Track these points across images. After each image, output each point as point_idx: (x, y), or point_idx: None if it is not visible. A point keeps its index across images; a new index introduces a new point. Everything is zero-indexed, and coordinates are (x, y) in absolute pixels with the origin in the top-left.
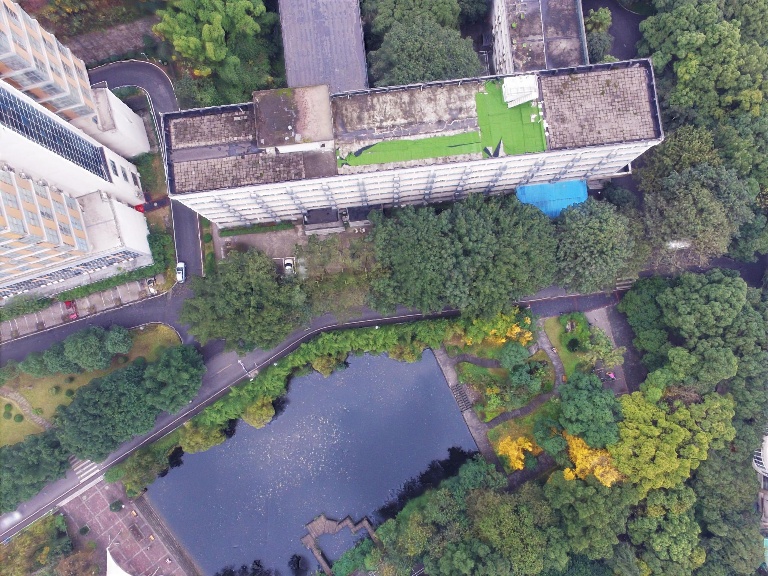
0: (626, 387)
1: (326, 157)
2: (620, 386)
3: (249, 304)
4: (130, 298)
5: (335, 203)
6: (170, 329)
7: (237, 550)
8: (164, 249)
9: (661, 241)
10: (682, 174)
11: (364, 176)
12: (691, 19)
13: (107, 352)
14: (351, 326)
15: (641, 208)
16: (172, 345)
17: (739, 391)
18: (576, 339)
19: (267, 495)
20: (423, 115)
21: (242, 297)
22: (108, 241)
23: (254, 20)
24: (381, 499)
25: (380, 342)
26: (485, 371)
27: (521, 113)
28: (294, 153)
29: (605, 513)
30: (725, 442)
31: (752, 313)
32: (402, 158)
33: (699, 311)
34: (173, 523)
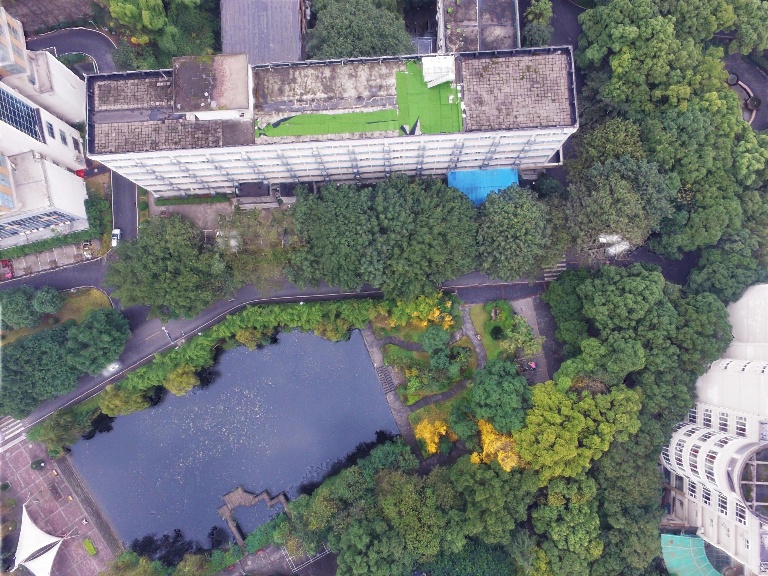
0: (548, 378)
1: (244, 126)
2: (542, 377)
3: (166, 269)
4: (65, 261)
5: (264, 176)
6: (102, 294)
7: (154, 516)
8: (101, 215)
9: (578, 230)
10: (605, 165)
11: (280, 147)
12: (625, 12)
13: (35, 311)
14: (278, 301)
15: (567, 199)
16: None
17: (648, 385)
18: (499, 327)
19: (187, 464)
20: (343, 91)
21: (159, 261)
22: (38, 200)
23: None
24: (299, 475)
25: (304, 318)
26: (410, 354)
27: (440, 94)
28: (213, 121)
29: (500, 496)
30: (630, 435)
31: (667, 308)
32: (319, 132)
33: (613, 302)
34: (93, 485)
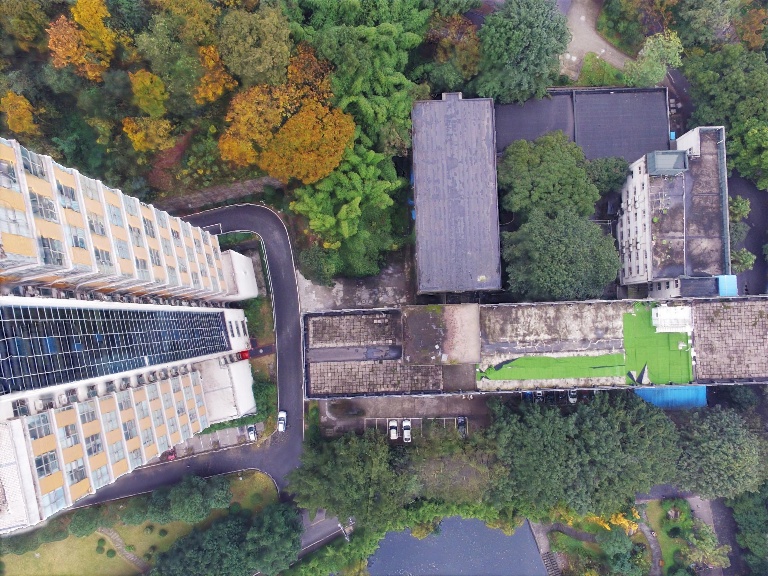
0: None
1: (465, 368)
2: (716, 575)
3: (367, 494)
4: (229, 442)
5: None
6: (267, 477)
7: None
8: (267, 398)
9: None
10: None
11: None
12: None
13: (208, 505)
14: None
15: (764, 413)
16: (268, 493)
17: None
18: (678, 528)
19: None
20: (568, 332)
21: (362, 489)
22: (224, 408)
23: None
24: None
25: (481, 516)
26: (579, 544)
27: (669, 339)
28: None
29: None
30: None
31: None
32: (543, 376)
33: None
34: None
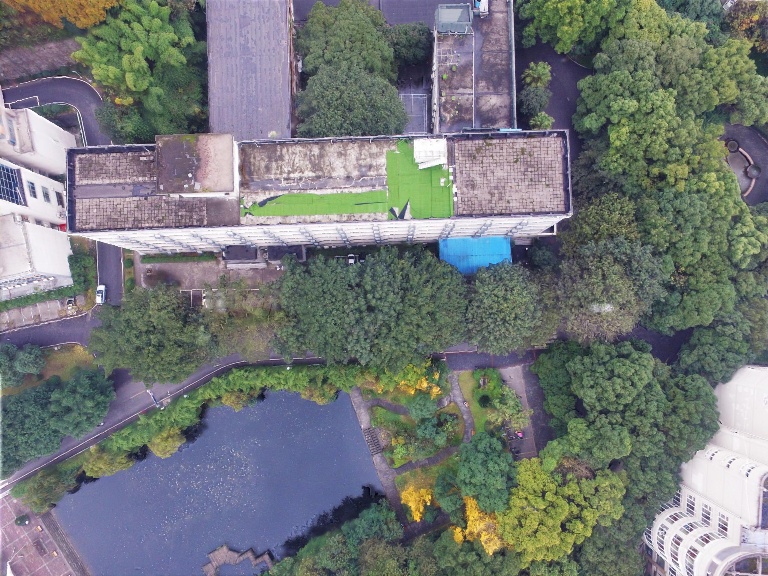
0: (534, 447)
1: (230, 205)
2: (528, 445)
3: (150, 342)
4: (49, 316)
5: (251, 243)
6: None
7: (139, 572)
8: (85, 270)
9: (569, 313)
10: (598, 245)
11: (266, 227)
12: (625, 85)
13: (18, 371)
14: (265, 363)
15: (560, 273)
16: (87, 367)
17: (633, 469)
18: (487, 396)
19: (172, 521)
20: (332, 169)
21: (142, 335)
22: (19, 265)
23: (184, 49)
24: (284, 534)
25: (290, 383)
26: (397, 418)
27: (431, 175)
28: (198, 198)
29: None
30: (613, 519)
31: (655, 392)
32: (306, 212)
33: (601, 386)
34: (78, 541)
